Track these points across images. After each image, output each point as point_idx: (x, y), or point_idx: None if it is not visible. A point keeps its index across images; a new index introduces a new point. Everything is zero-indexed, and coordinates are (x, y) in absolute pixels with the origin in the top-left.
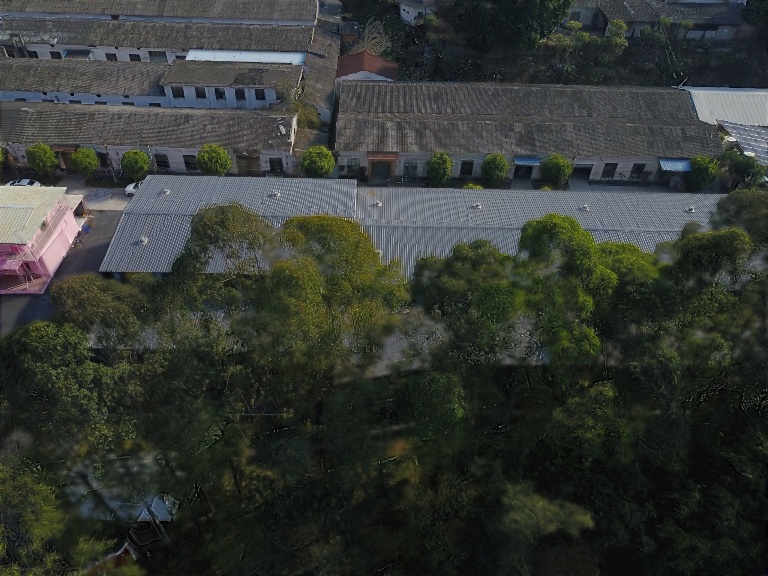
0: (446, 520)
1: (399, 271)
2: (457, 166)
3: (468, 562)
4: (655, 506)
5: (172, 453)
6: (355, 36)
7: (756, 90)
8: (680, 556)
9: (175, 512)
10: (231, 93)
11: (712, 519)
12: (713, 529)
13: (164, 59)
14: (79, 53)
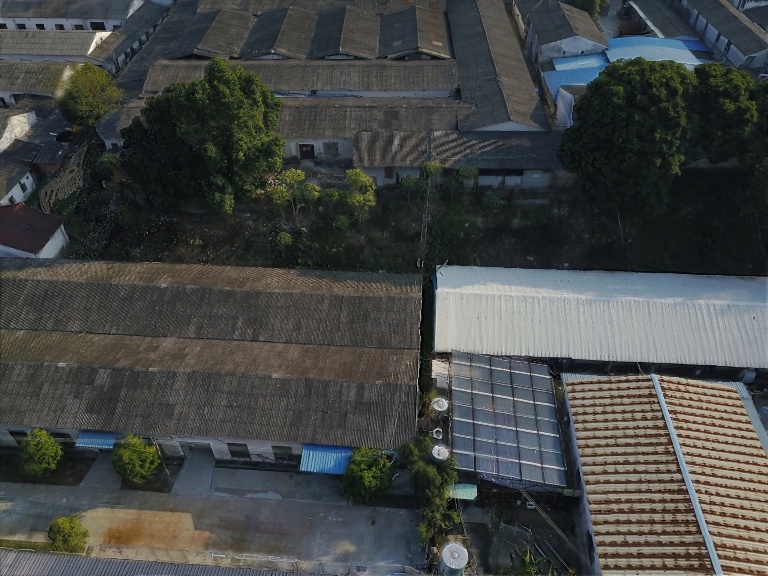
0: None
1: None
2: (6, 435)
3: None
4: None
5: None
6: (57, 165)
7: (553, 281)
8: None
9: None
10: None
11: None
12: None
13: None
14: None
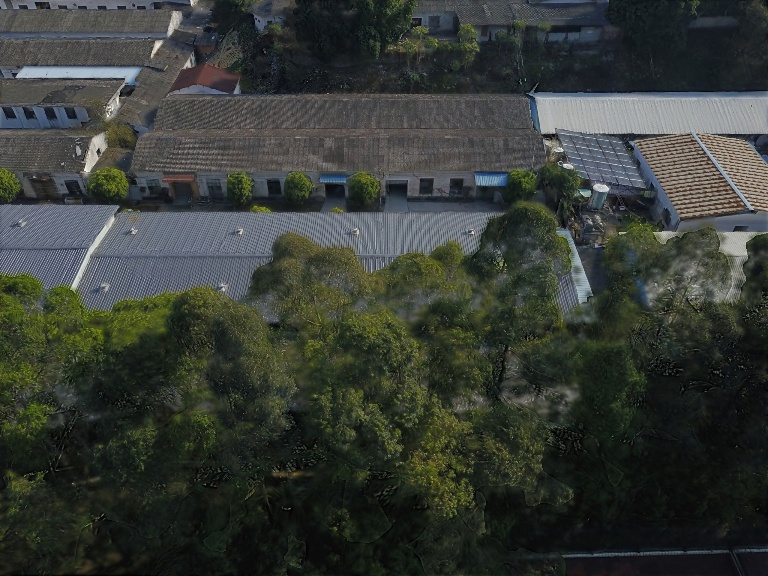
0: None
1: None
2: (263, 185)
3: None
4: None
5: None
6: (212, 47)
7: (612, 95)
8: None
9: None
10: (41, 112)
11: None
12: None
13: (1, 77)
14: None
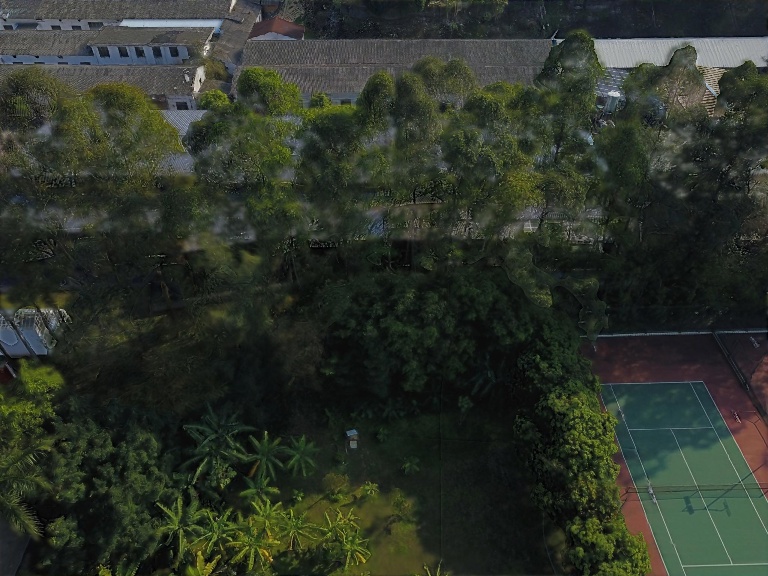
0: (206, 304)
1: (156, 116)
2: None
3: (228, 340)
4: (382, 307)
5: (2, 252)
6: (276, 7)
7: None
8: (398, 342)
9: (51, 348)
10: (149, 51)
11: (422, 314)
12: (423, 321)
13: None
14: (28, 26)
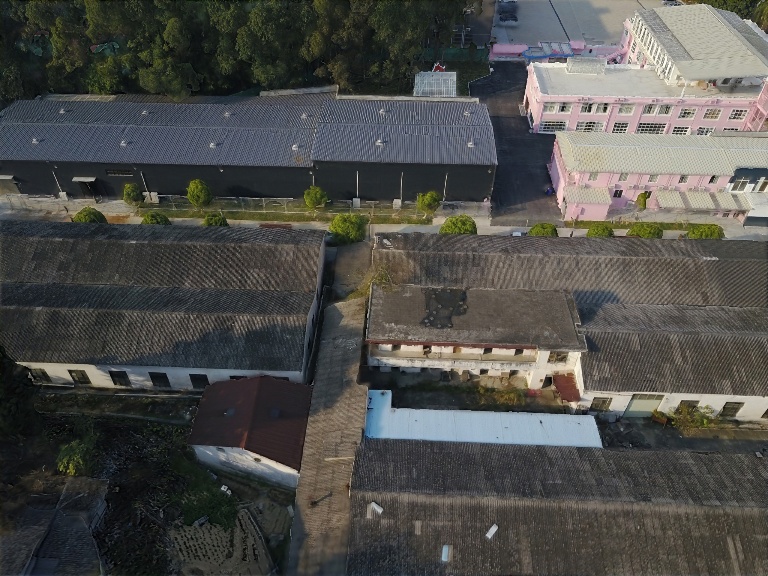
0: None
1: None
2: None
3: None
4: None
5: None
6: None
7: None
8: None
9: None
10: None
11: None
12: None
13: None
14: None
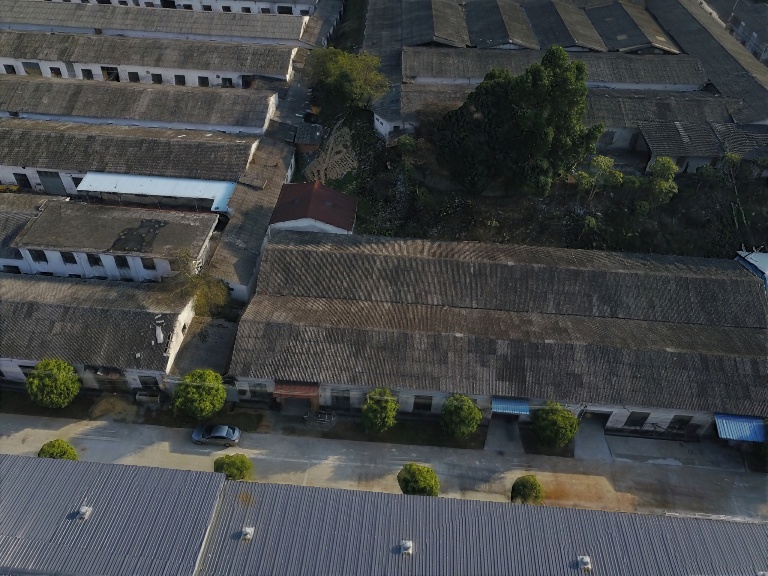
0: None
1: None
2: (408, 400)
3: None
4: None
5: None
6: (316, 146)
7: None
8: None
9: None
10: (109, 260)
11: None
12: None
13: (58, 180)
14: None
